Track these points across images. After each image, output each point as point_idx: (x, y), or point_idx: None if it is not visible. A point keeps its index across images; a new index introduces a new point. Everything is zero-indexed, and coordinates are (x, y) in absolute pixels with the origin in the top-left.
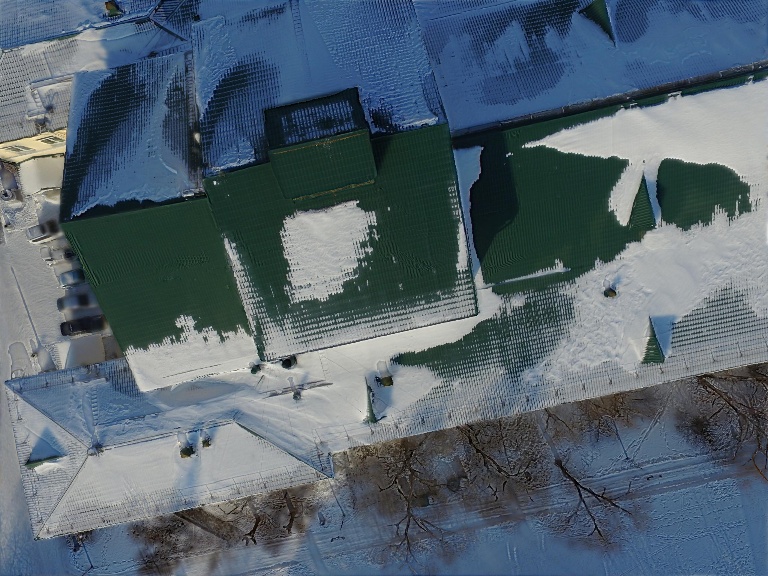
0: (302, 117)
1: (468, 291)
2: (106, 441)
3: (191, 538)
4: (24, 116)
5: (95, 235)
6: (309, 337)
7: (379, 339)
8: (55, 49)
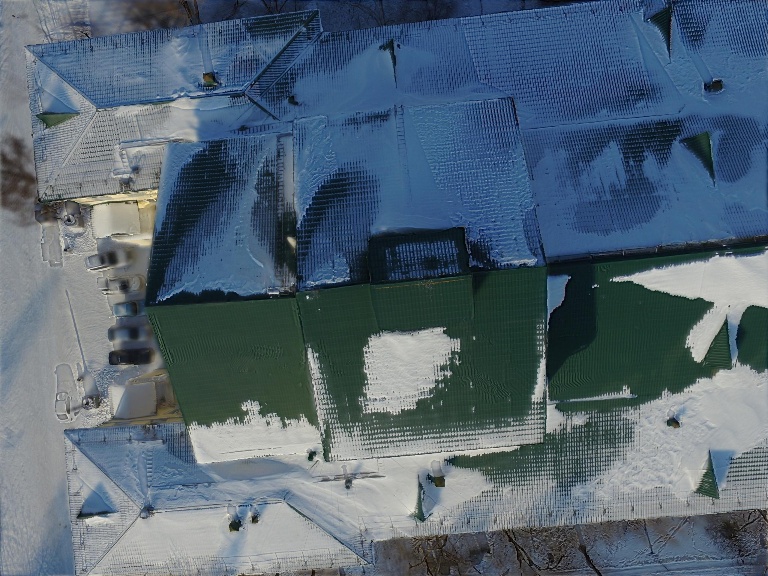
0: (406, 252)
1: (539, 421)
2: (158, 504)
3: None
4: (109, 174)
5: (176, 318)
6: (376, 445)
7: None
8: (148, 113)
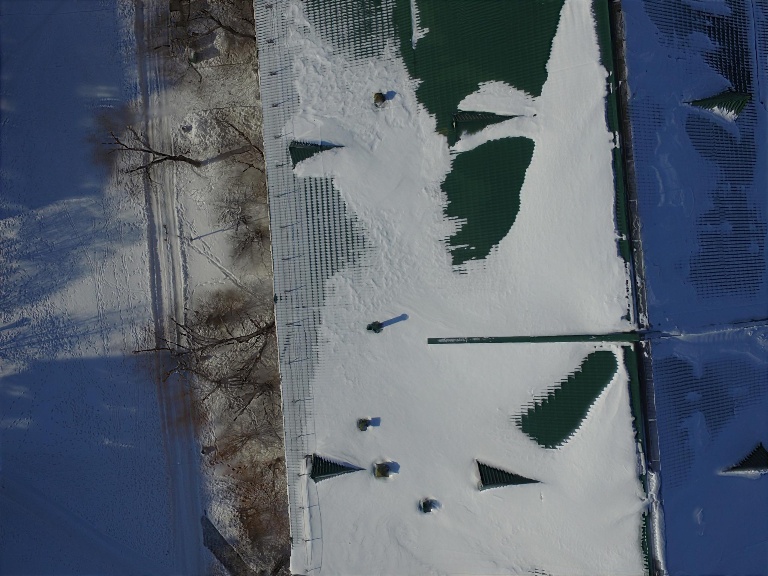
0: None
1: None
2: None
3: None
4: None
5: None
6: None
7: None
8: None
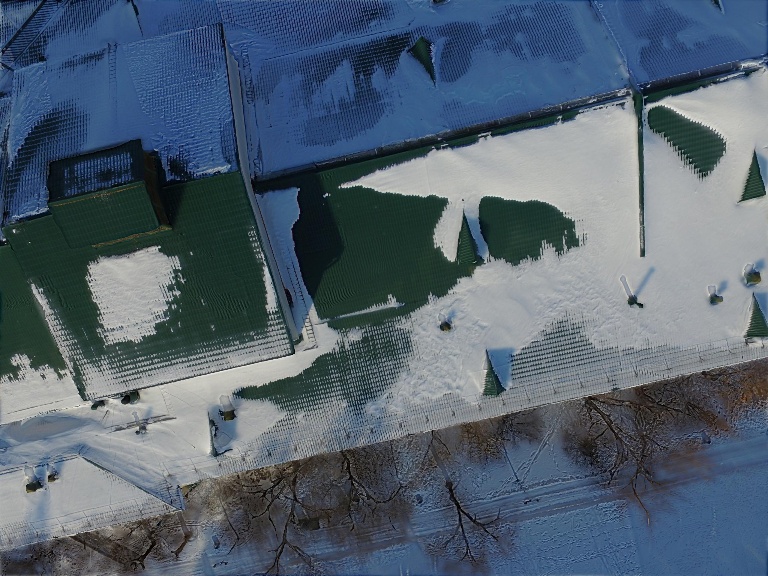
0: (84, 169)
1: (281, 331)
2: None
3: (88, 562)
4: None
5: None
6: (128, 377)
7: (219, 374)
8: None
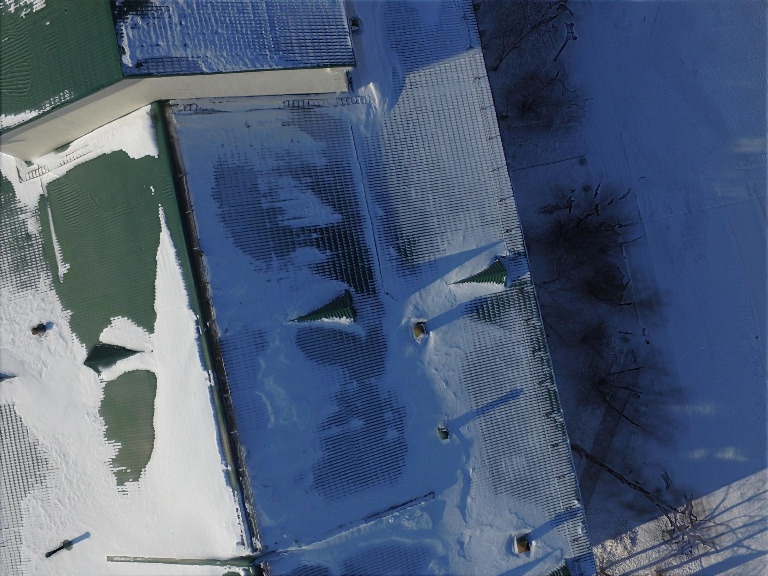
0: None
1: None
2: None
3: None
4: None
5: None
6: None
7: None
8: None
